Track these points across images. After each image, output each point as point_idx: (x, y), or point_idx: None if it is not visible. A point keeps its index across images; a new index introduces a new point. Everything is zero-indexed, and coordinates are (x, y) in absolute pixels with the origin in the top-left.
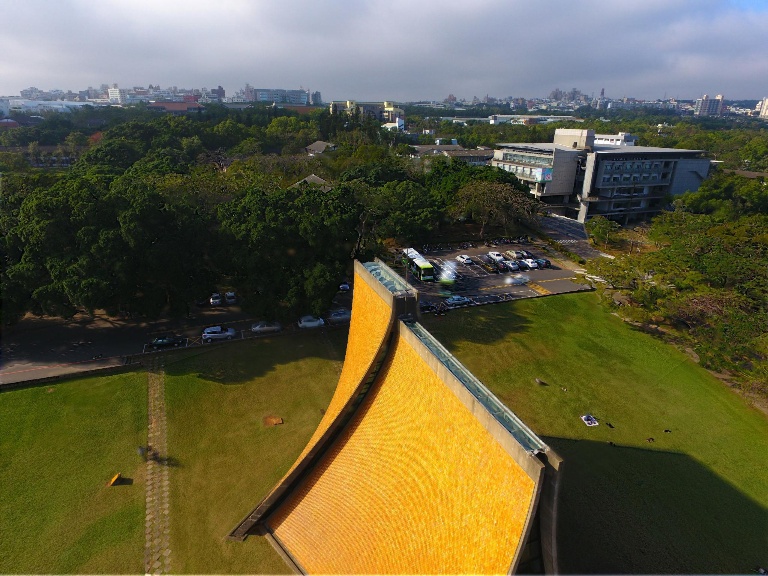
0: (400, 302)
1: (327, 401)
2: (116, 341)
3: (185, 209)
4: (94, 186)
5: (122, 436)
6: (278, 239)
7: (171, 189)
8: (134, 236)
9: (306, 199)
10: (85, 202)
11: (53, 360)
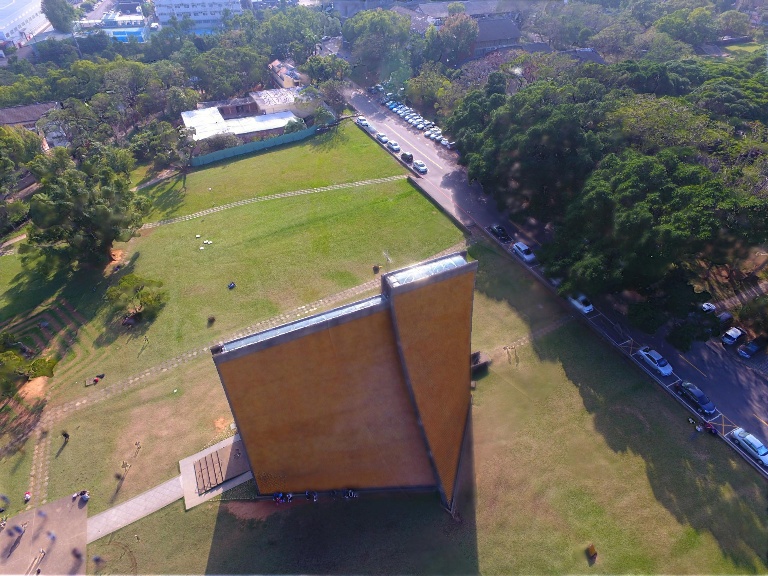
0: (386, 283)
1: (474, 342)
2: (492, 211)
3: (592, 142)
4: (559, 94)
5: (409, 255)
6: (601, 211)
7: (621, 117)
8: (521, 147)
9: (688, 191)
10: (530, 106)
11: (460, 199)
